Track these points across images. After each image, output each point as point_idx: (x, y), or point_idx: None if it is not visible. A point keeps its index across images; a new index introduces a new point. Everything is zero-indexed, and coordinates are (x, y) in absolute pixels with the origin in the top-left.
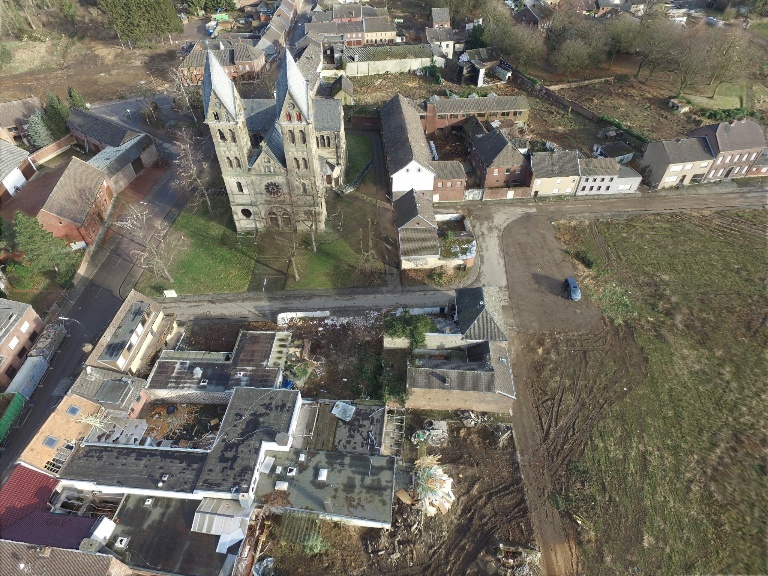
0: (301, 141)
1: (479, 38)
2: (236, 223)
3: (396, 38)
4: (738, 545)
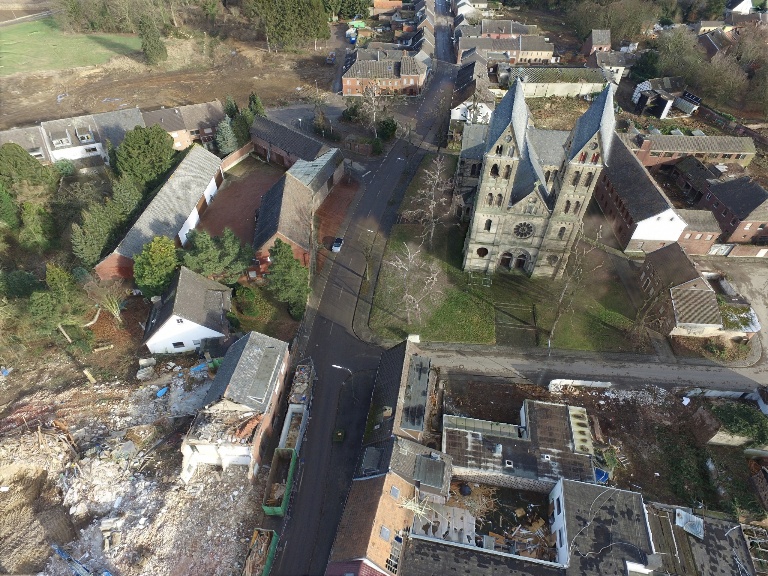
0: (583, 183)
1: (650, 65)
2: (466, 261)
3: (551, 58)
4: None
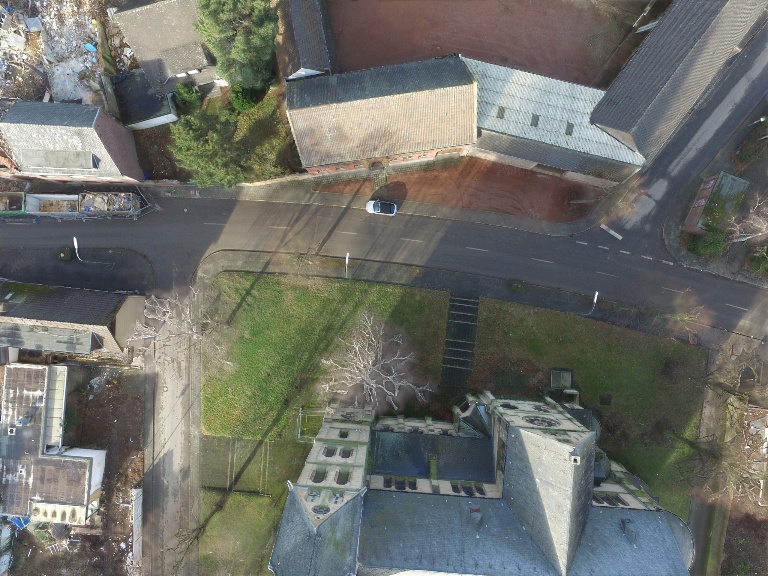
0: None
1: None
2: None
3: None
4: None
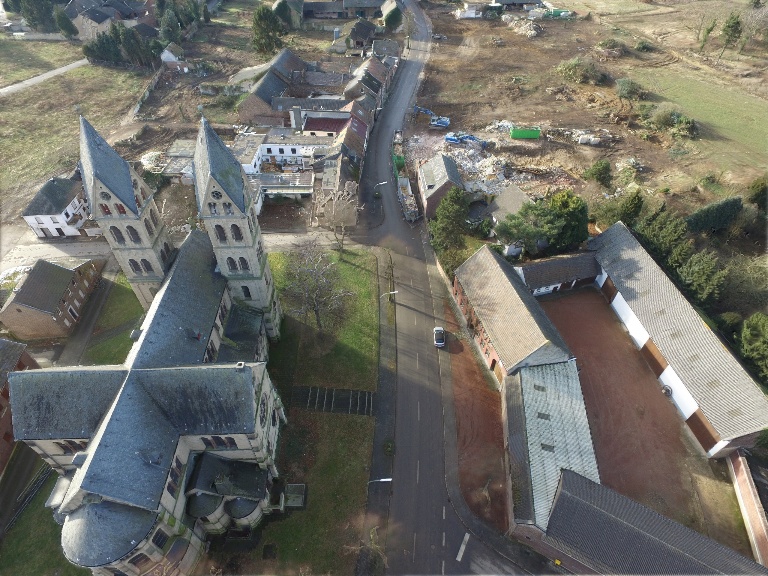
0: None
1: None
2: None
3: None
4: (18, 147)
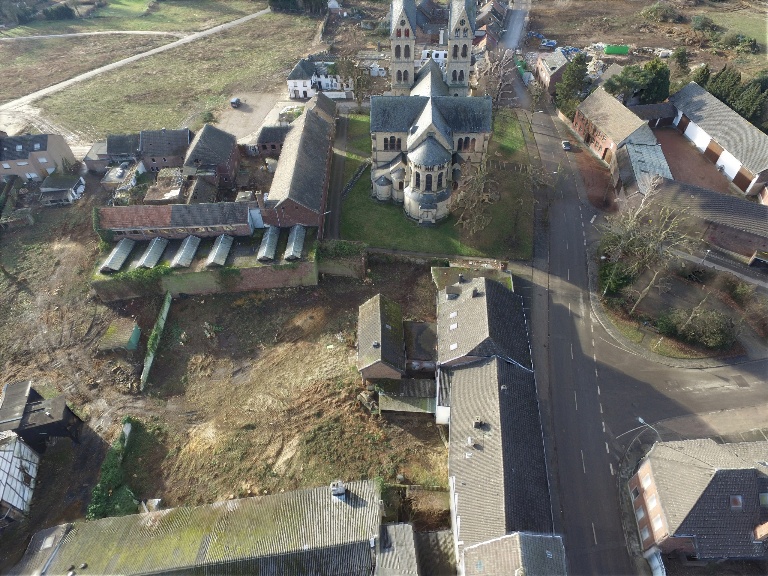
0: None
1: None
2: None
3: None
4: None
